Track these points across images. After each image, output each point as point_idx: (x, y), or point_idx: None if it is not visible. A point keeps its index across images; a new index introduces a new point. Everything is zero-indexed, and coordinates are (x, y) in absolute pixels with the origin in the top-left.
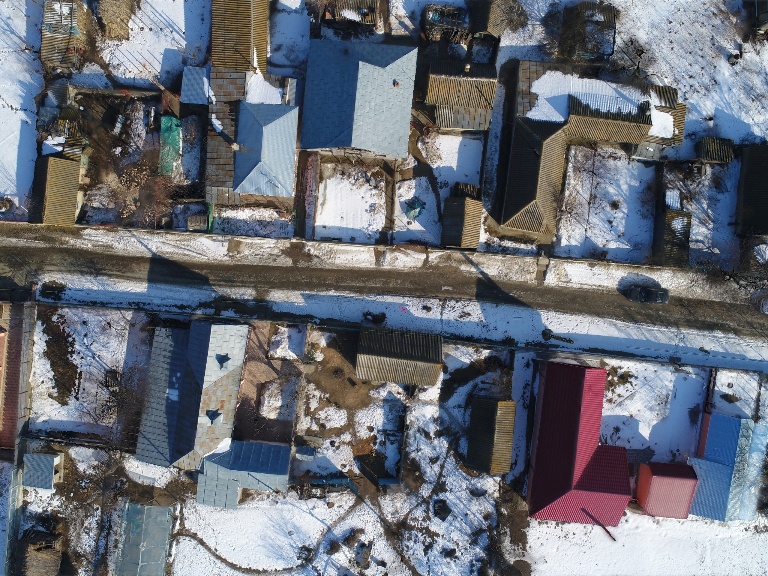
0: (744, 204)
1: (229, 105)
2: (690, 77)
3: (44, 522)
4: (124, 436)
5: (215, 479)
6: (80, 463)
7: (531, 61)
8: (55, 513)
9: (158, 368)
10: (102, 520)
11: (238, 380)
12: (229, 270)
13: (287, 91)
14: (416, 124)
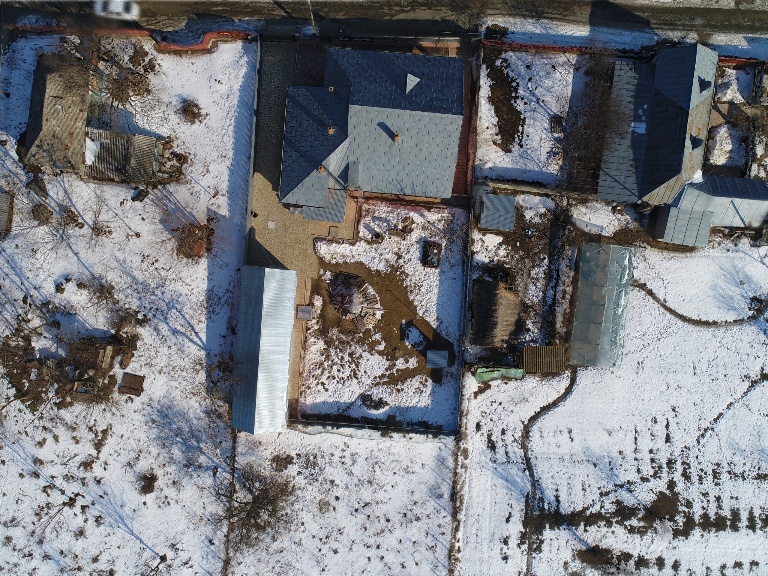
0: None
1: None
2: None
3: (490, 273)
4: (585, 174)
5: (688, 212)
6: (528, 210)
7: None
8: (501, 263)
9: (621, 102)
10: (550, 270)
11: (709, 110)
12: (670, 13)
13: None
14: None
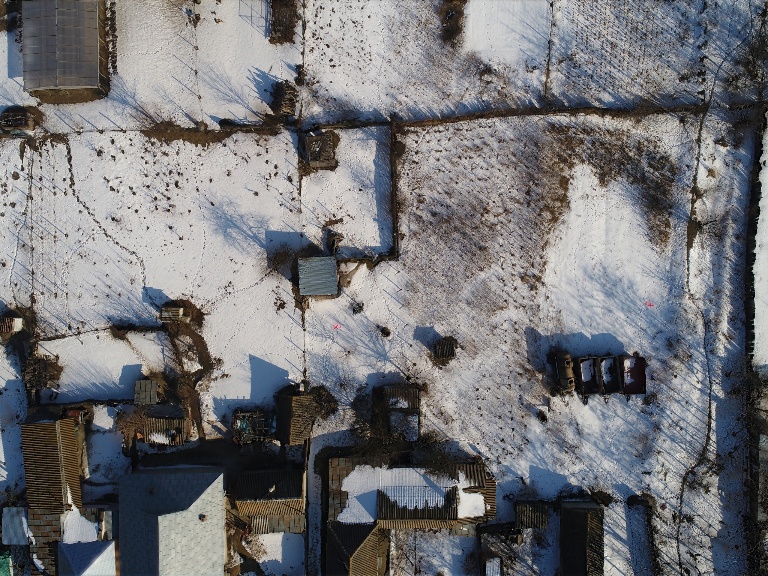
0: (563, 566)
1: (48, 545)
2: (501, 441)
3: None
4: None
5: None
6: None
7: (340, 458)
8: None
9: None
10: None
11: None
12: None
13: (102, 526)
14: (238, 524)
